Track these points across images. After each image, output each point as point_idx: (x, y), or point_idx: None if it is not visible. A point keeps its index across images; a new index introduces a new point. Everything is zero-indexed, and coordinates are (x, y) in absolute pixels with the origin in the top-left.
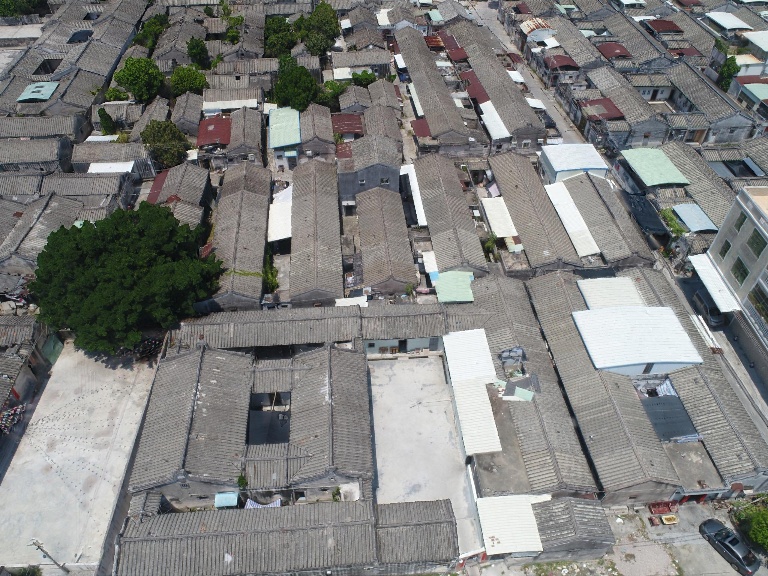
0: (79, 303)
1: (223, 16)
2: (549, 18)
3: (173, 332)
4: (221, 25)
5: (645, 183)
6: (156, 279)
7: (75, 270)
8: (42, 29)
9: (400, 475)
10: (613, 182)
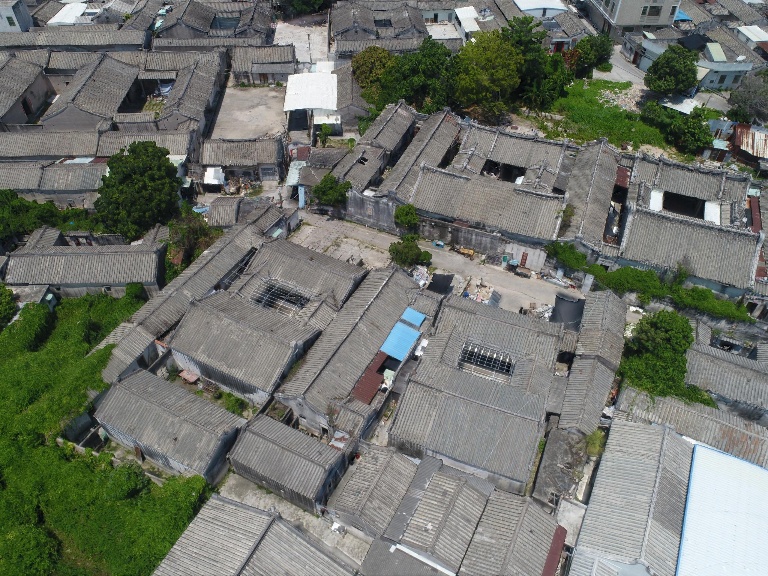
0: None
1: None
2: None
3: (334, 4)
4: None
5: None
6: None
7: None
8: None
9: None
10: None
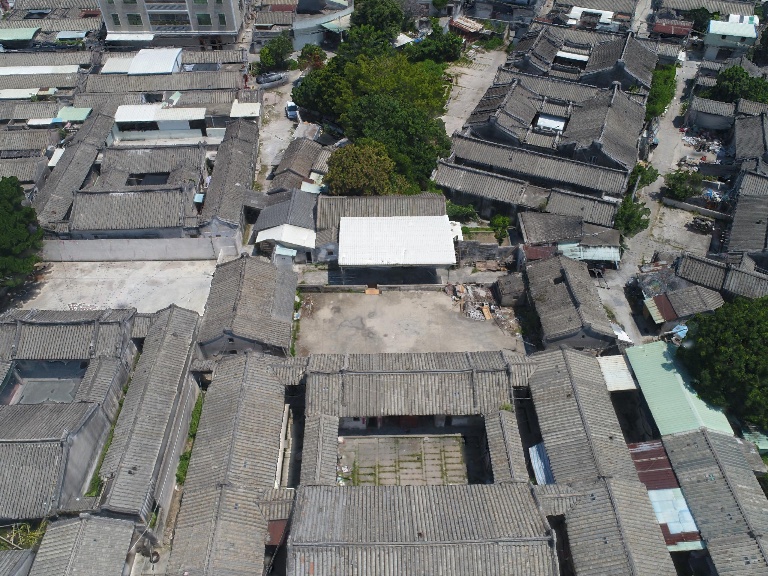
0: None
1: None
2: None
3: None
4: None
5: (27, 39)
6: None
7: None
8: None
9: None
10: None
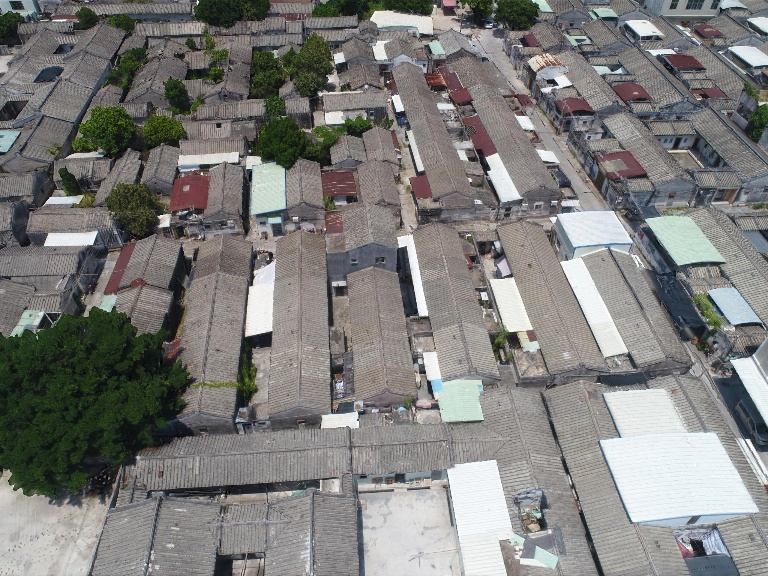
0: (12, 440)
1: (206, 49)
2: (559, 53)
3: (127, 468)
4: (204, 60)
5: (675, 261)
6: (104, 412)
7: (9, 397)
8: (8, 64)
9: None
10: (638, 258)
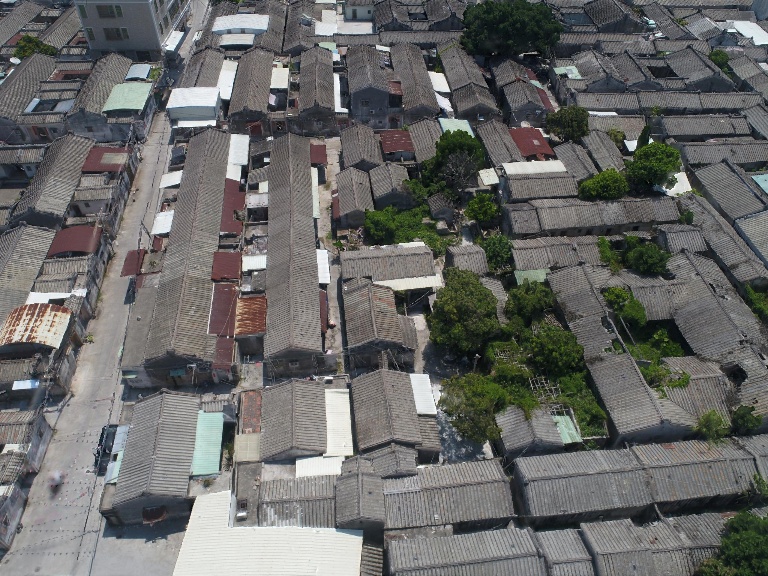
0: None
1: None
2: None
3: None
4: (680, 366)
5: None
6: None
7: None
8: None
9: None
10: None
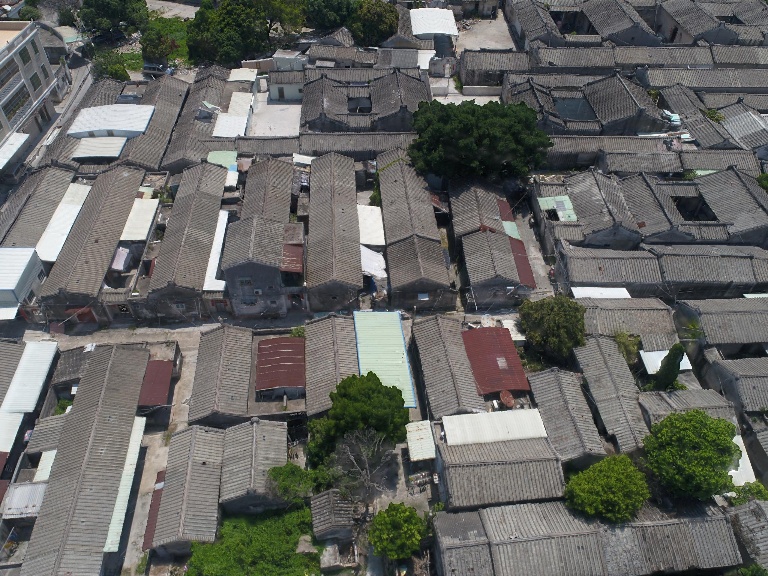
0: None
1: None
2: None
3: None
4: None
5: None
6: None
7: None
8: None
9: (290, 113)
10: None
